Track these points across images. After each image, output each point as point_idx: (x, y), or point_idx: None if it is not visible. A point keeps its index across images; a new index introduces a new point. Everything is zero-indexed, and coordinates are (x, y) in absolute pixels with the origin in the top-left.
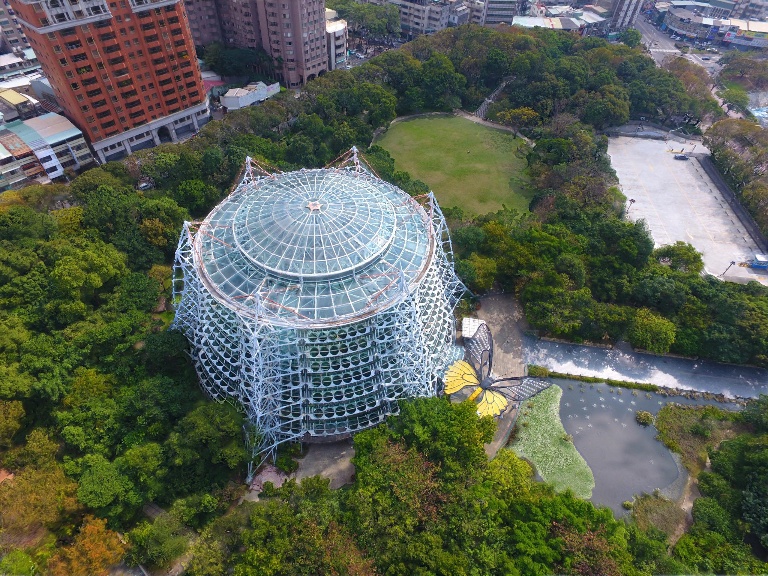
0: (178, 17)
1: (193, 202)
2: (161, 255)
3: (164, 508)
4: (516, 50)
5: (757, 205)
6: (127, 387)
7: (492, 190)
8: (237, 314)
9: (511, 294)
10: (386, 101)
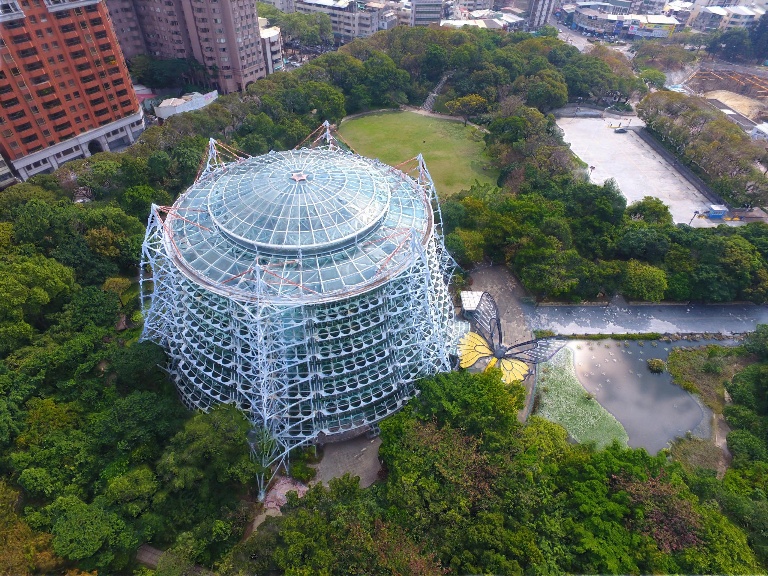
0: (101, 18)
1: (143, 210)
2: (115, 267)
3: (163, 549)
4: (452, 45)
5: (700, 162)
6: None
7: (456, 173)
8: (231, 299)
9: (499, 266)
10: (335, 98)
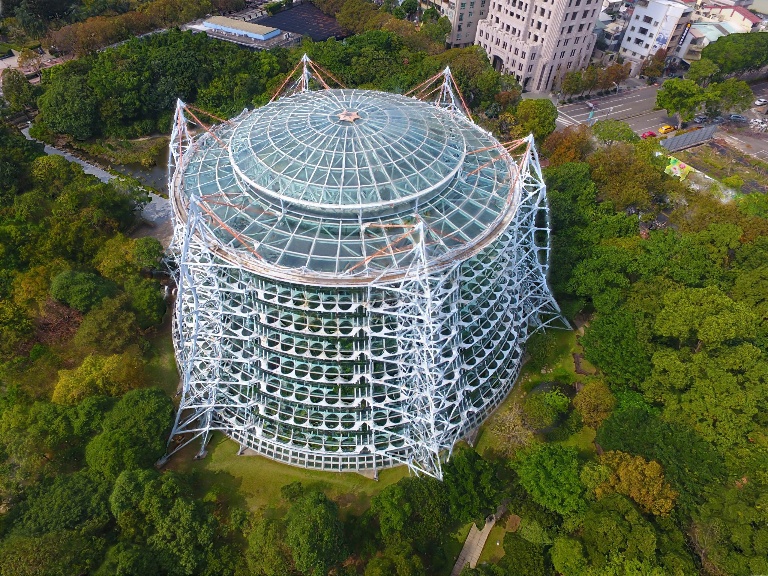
0: None
1: None
2: (603, 435)
3: None
4: None
5: None
6: None
7: None
8: None
9: None
10: None
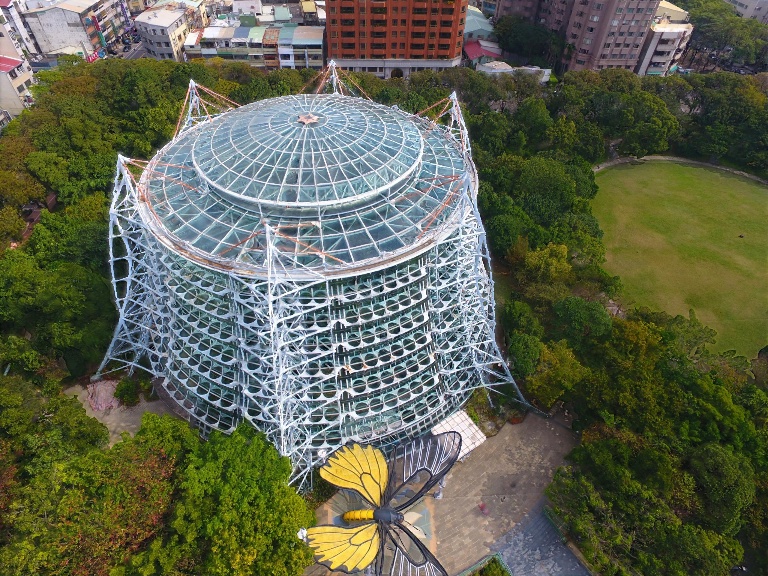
0: None
1: None
2: None
3: None
4: None
5: None
6: None
7: (727, 299)
8: None
9: None
10: (656, 121)
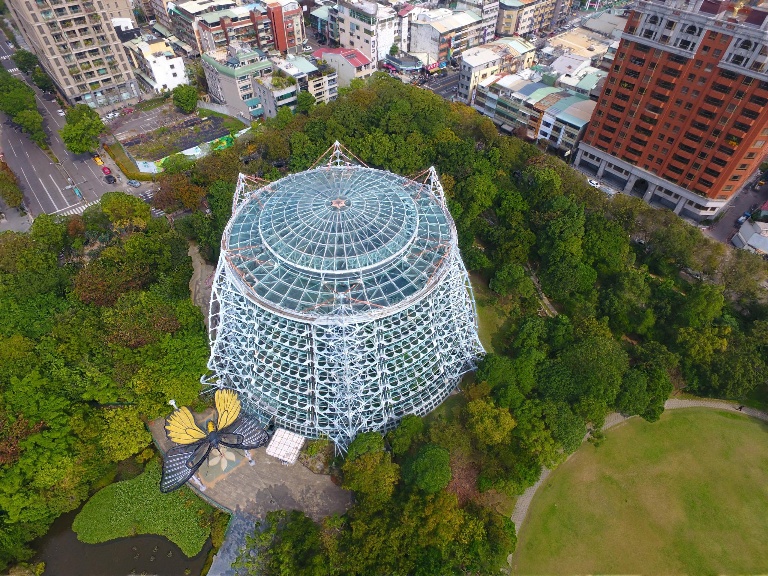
0: None
1: None
2: None
3: None
4: None
5: None
6: None
7: None
8: None
9: None
10: None
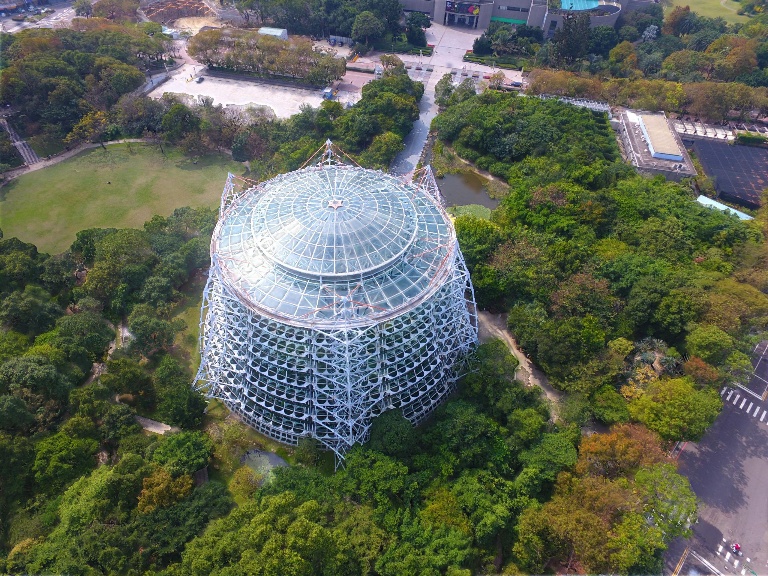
0: None
1: (85, 458)
2: (211, 483)
3: None
4: None
5: (284, 70)
6: (433, 480)
7: (188, 182)
8: None
9: None
10: None
